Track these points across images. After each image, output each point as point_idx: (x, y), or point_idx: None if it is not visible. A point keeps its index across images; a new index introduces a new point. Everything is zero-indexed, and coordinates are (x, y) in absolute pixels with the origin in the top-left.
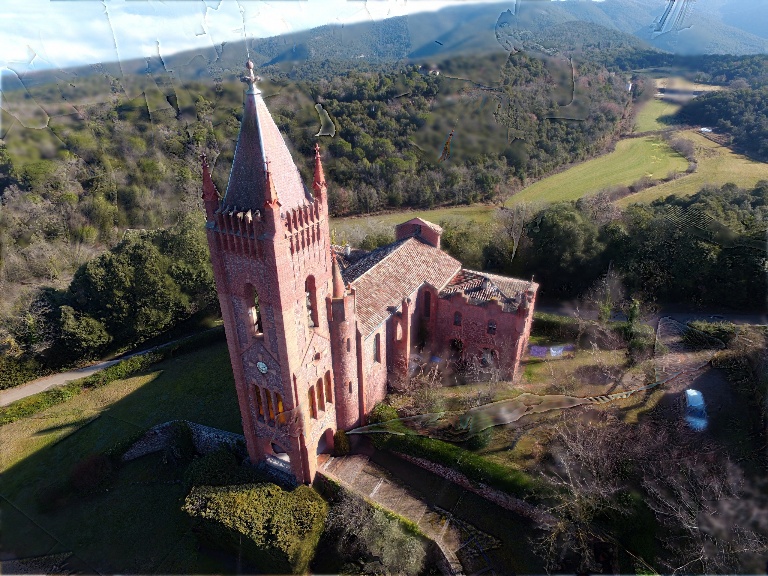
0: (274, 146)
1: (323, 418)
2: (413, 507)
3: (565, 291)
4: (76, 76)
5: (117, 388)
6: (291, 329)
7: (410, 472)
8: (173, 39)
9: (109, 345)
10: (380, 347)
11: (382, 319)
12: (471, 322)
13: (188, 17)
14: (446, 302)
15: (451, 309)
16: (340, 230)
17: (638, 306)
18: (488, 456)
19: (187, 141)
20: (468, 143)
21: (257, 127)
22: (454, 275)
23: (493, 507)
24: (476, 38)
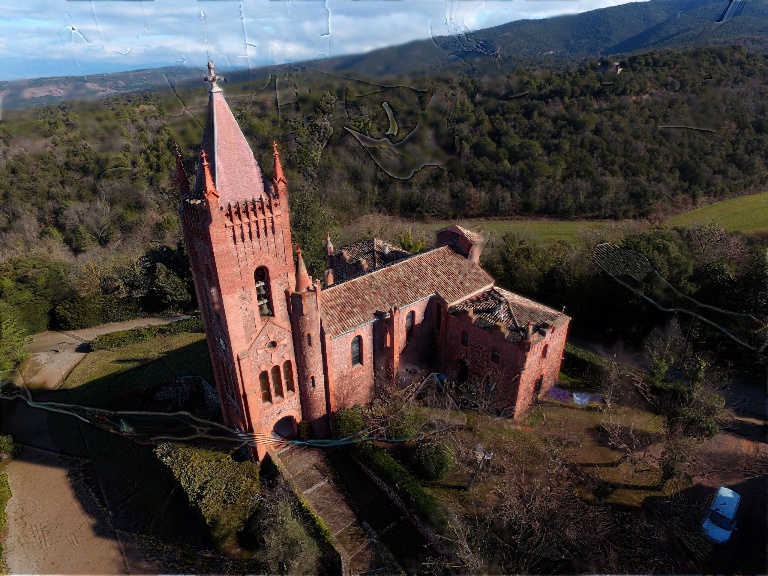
0: (231, 141)
1: (281, 404)
2: (342, 515)
3: (634, 333)
4: (219, 72)
5: (181, 339)
6: (235, 313)
7: (358, 481)
8: (301, 39)
9: (191, 302)
10: (363, 350)
11: (363, 322)
12: (477, 345)
13: (316, 19)
14: (455, 318)
15: (459, 327)
16: (428, 230)
17: (704, 368)
18: (437, 489)
19: (310, 132)
20: (427, 150)
21: (213, 123)
22: (480, 291)
23: (423, 544)
24: (407, 36)
